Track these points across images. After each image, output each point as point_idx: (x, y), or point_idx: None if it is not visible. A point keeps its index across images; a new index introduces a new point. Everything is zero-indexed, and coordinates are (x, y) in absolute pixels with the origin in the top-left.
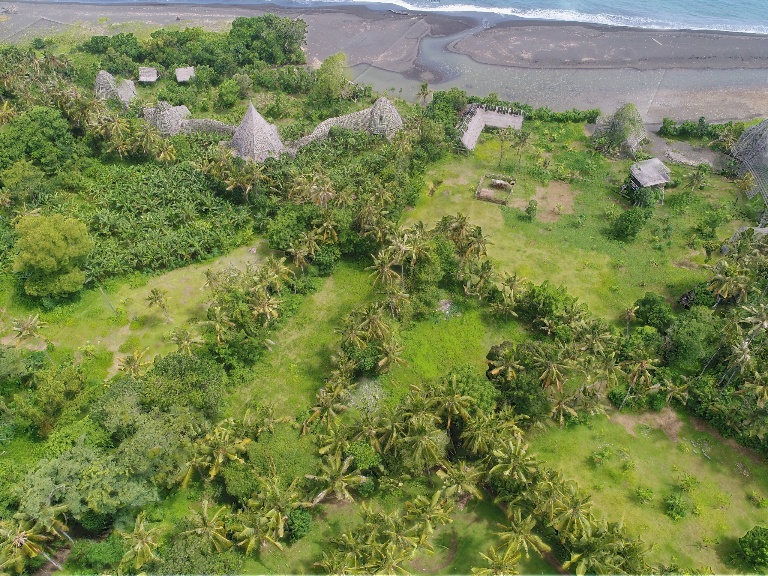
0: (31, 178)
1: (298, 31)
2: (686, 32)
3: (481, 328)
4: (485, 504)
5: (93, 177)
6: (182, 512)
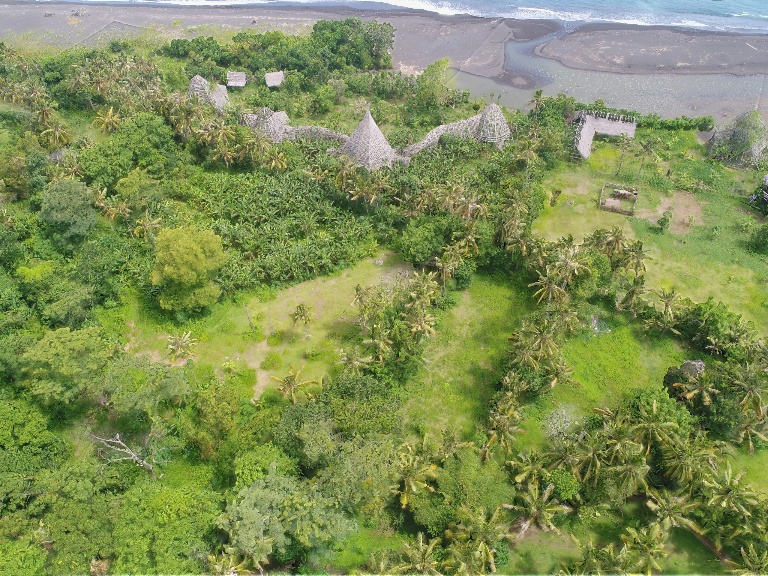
0: (147, 187)
1: (387, 35)
2: None
3: (636, 346)
4: (681, 534)
5: (198, 185)
6: (362, 541)
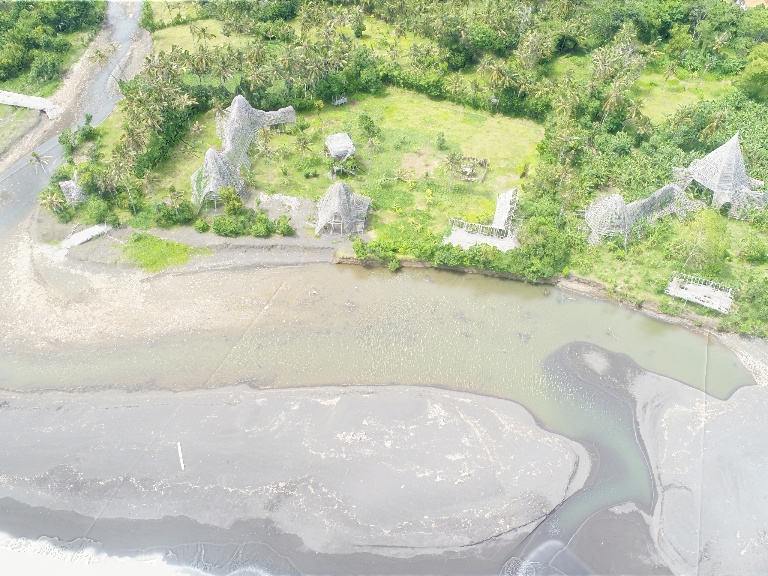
0: None
1: None
2: (89, 516)
3: None
4: None
5: None
6: None
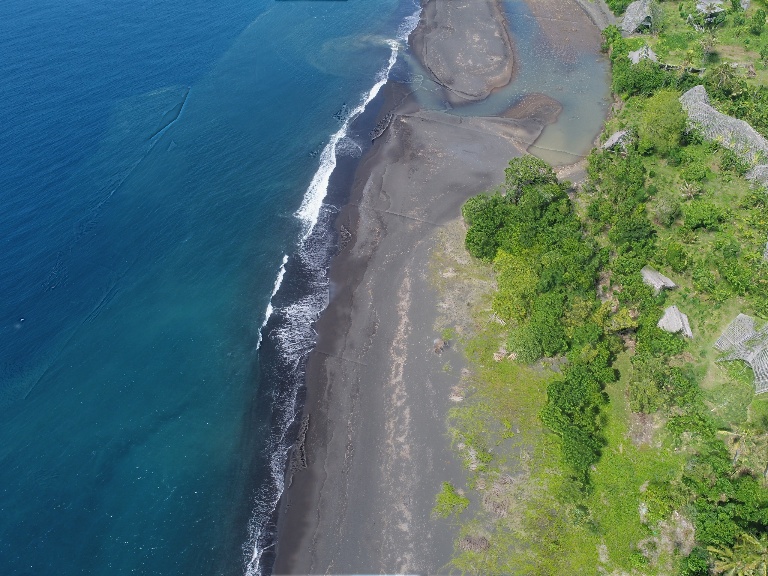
0: None
1: None
2: None
3: None
4: None
5: None
6: None
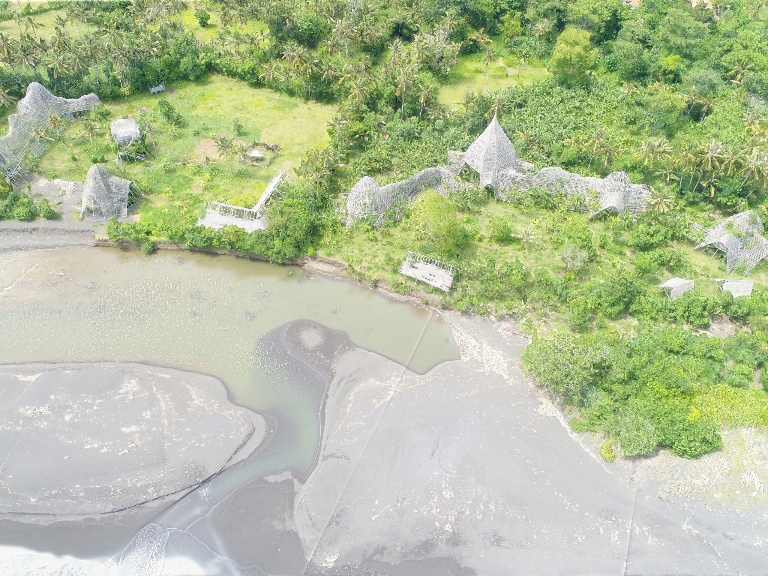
0: None
1: None
2: None
3: None
4: None
5: None
6: None
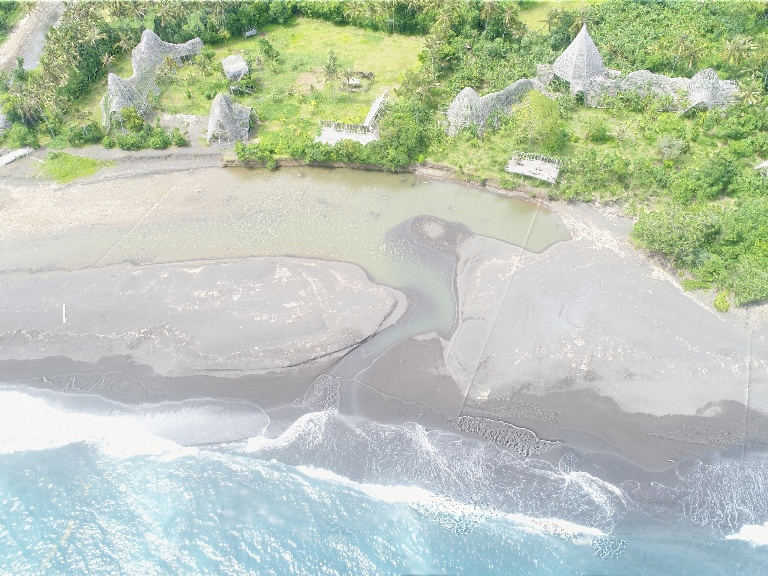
0: None
1: None
2: None
3: None
4: None
5: None
6: None
